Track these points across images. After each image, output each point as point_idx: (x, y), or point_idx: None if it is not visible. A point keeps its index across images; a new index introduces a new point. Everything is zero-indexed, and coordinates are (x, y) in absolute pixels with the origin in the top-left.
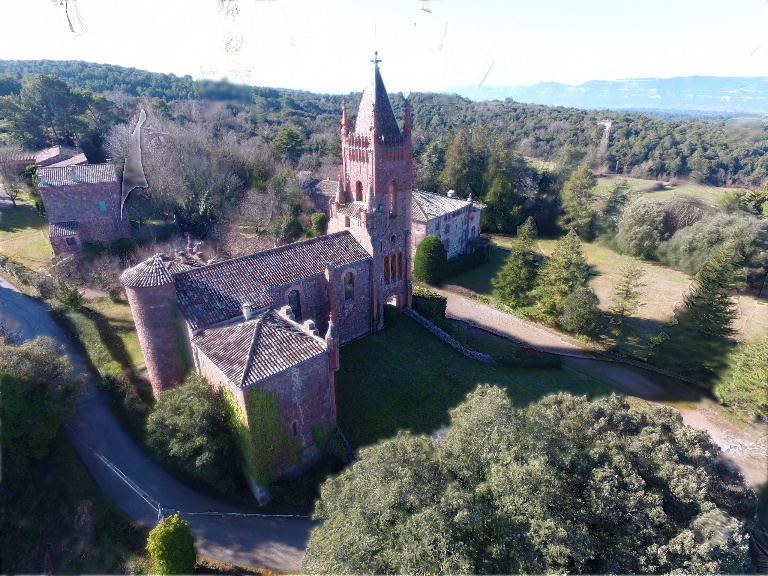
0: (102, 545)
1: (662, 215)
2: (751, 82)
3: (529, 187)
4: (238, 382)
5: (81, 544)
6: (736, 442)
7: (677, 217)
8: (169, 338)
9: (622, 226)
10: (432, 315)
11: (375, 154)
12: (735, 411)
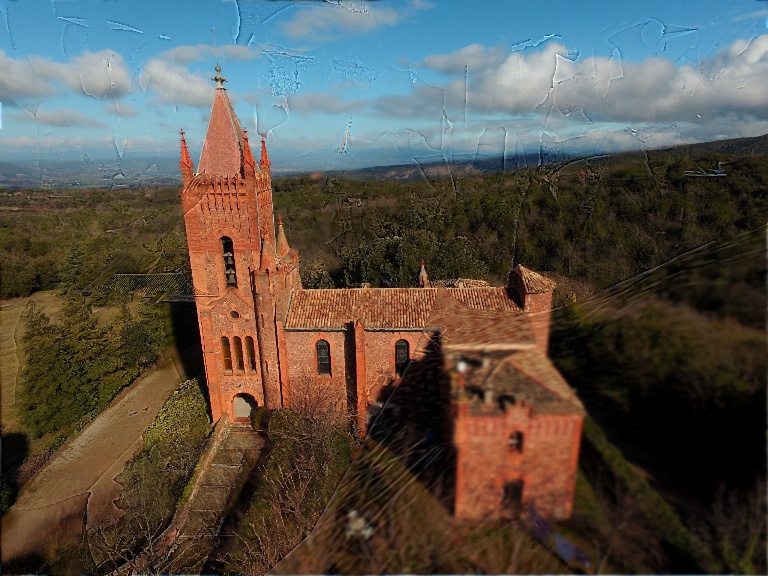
0: None
1: None
2: None
3: None
4: None
5: None
6: None
7: None
8: None
9: None
10: None
11: None
12: None
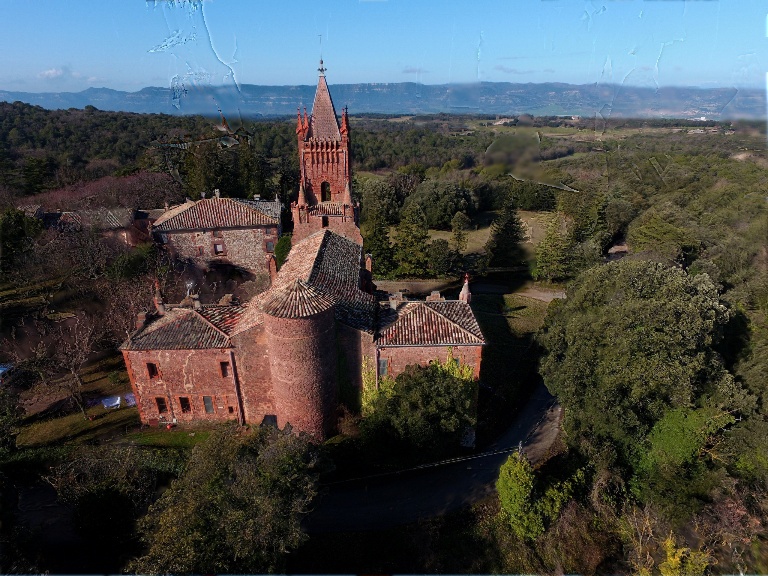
0: (440, 549)
1: (394, 189)
2: (421, 91)
3: (274, 186)
4: (477, 340)
5: (426, 564)
6: (558, 295)
7: (401, 189)
8: (333, 361)
9: (367, 203)
10: (376, 291)
11: (347, 154)
12: (542, 282)
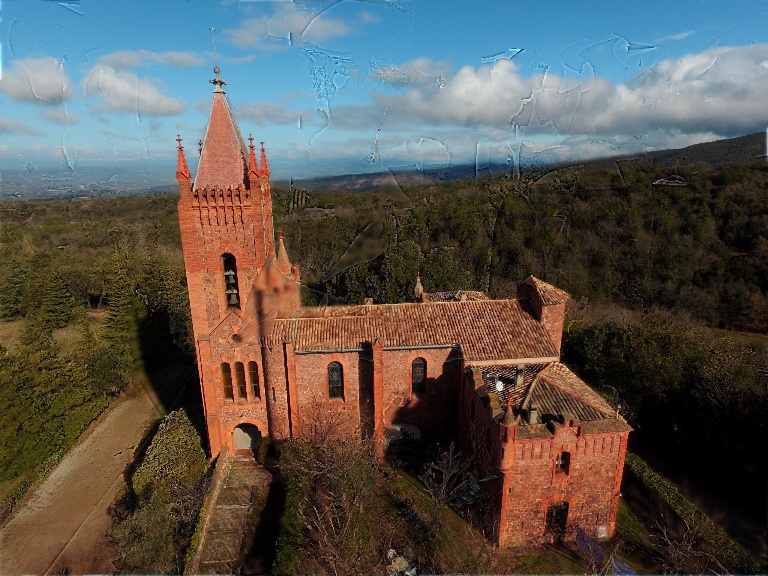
0: None
1: None
2: None
3: None
4: None
5: None
6: None
7: None
8: None
9: None
10: None
11: None
12: None
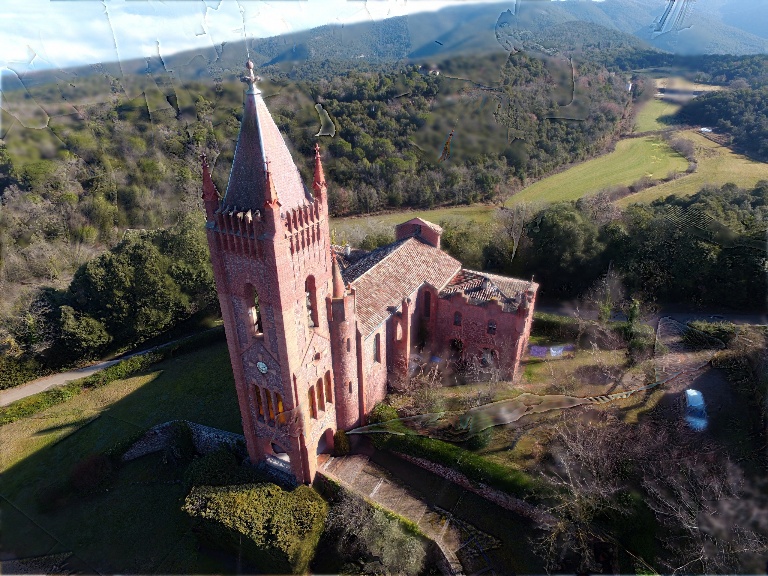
0: None
1: None
2: None
3: None
4: None
5: None
6: None
7: None
8: None
9: None
10: None
11: None
12: None
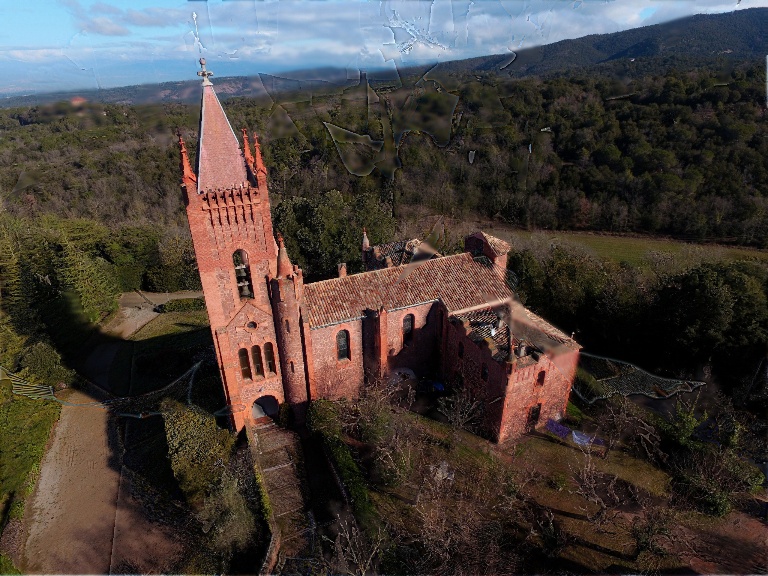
0: None
1: None
2: None
3: None
4: None
5: None
6: (131, 315)
7: None
8: None
9: None
10: None
11: None
12: None
